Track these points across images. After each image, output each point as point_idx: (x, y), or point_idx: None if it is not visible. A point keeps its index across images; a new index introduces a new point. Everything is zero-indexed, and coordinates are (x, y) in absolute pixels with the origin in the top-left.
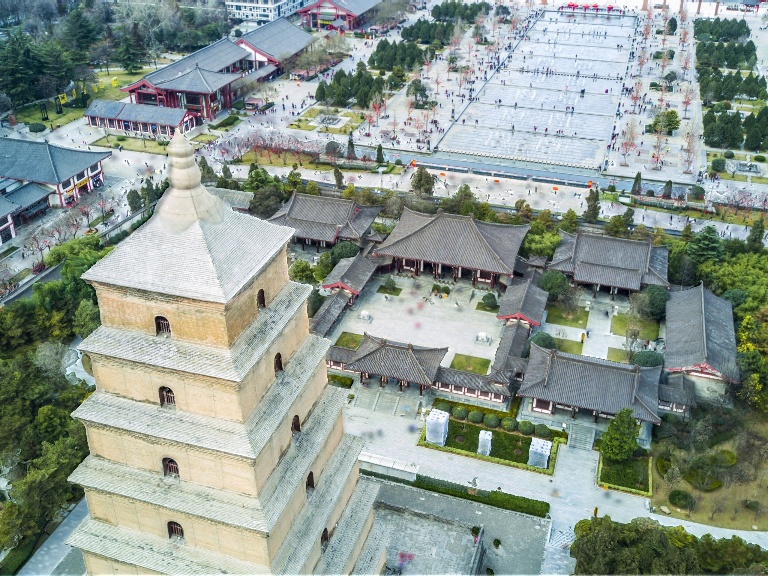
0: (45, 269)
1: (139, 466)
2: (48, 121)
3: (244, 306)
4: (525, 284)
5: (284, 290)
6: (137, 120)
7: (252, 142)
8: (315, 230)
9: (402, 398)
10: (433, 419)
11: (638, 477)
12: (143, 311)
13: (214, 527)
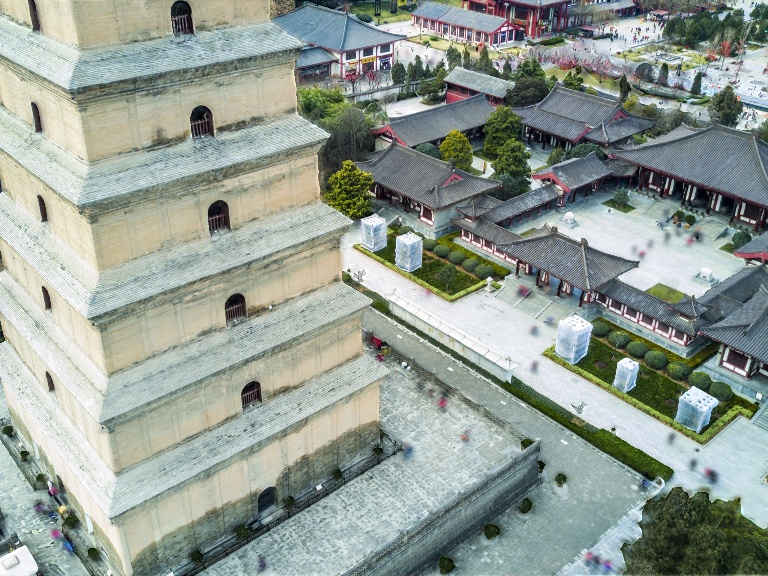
0: None
1: (22, 117)
2: (379, 17)
3: None
4: None
5: None
6: (456, 23)
7: (560, 57)
8: (560, 125)
9: (555, 303)
10: (567, 324)
11: None
12: None
13: (59, 204)
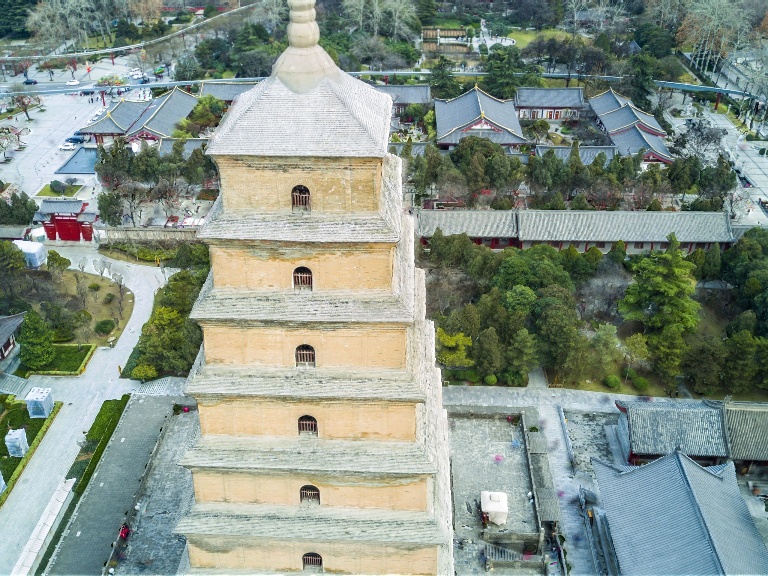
0: None
1: None
2: None
3: None
4: None
5: None
6: None
7: None
8: None
9: None
10: None
11: (73, 351)
12: None
13: None
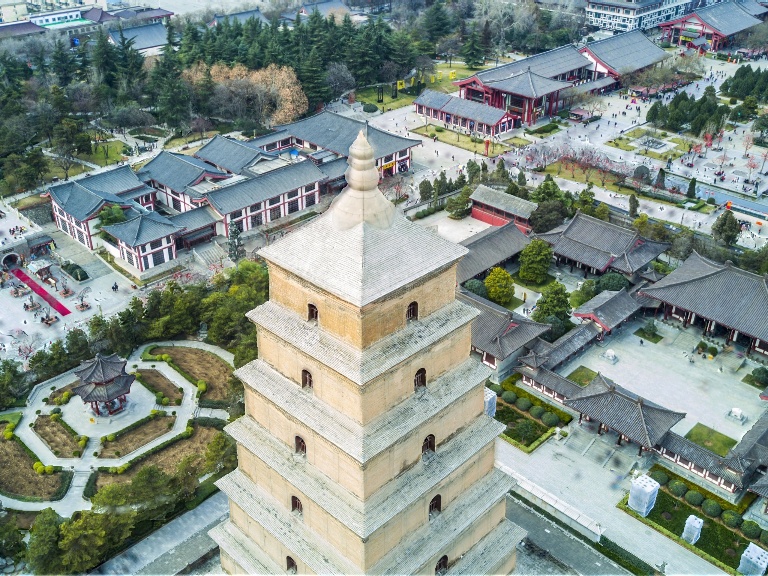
0: None
1: (278, 436)
2: (382, 103)
3: (389, 314)
4: None
5: (446, 308)
6: (458, 114)
7: (561, 153)
8: (587, 254)
9: (617, 452)
10: (639, 485)
11: None
12: (300, 296)
13: (325, 515)
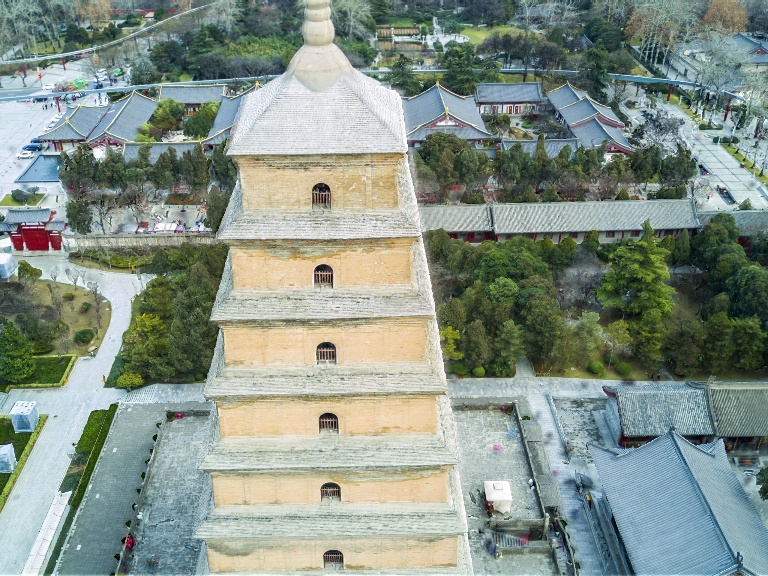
0: None
1: None
2: None
3: None
4: None
5: None
6: None
7: None
8: None
9: None
10: None
11: (53, 362)
12: None
13: None
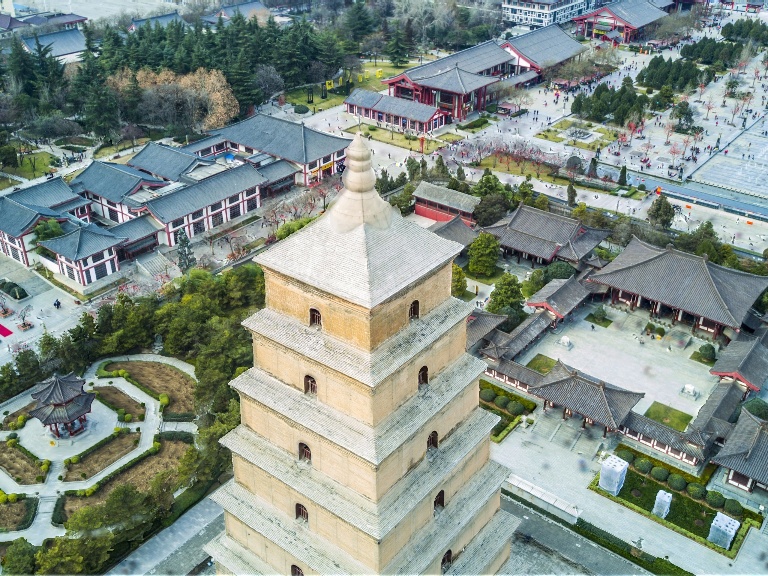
0: (275, 241)
1: (279, 444)
2: (312, 104)
3: (394, 314)
4: (752, 342)
5: (443, 305)
6: (390, 112)
7: (494, 147)
8: (533, 245)
9: (583, 435)
10: (609, 465)
11: None
12: (300, 301)
13: (334, 520)
